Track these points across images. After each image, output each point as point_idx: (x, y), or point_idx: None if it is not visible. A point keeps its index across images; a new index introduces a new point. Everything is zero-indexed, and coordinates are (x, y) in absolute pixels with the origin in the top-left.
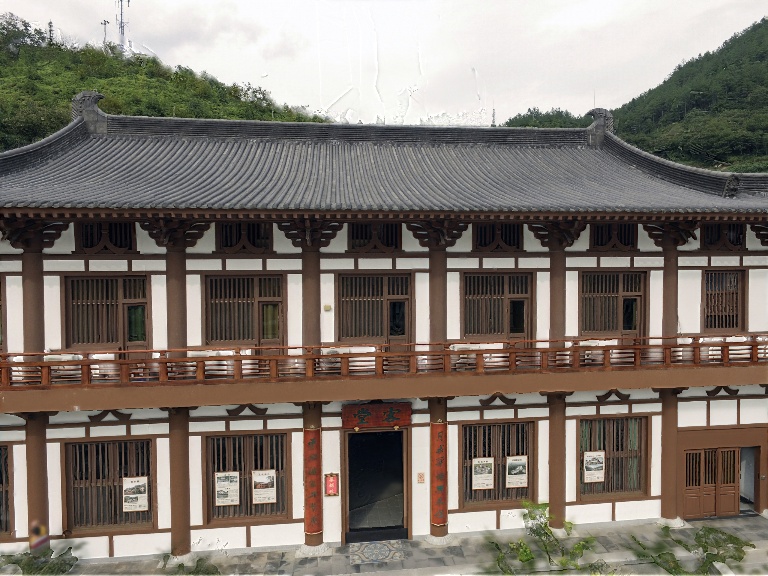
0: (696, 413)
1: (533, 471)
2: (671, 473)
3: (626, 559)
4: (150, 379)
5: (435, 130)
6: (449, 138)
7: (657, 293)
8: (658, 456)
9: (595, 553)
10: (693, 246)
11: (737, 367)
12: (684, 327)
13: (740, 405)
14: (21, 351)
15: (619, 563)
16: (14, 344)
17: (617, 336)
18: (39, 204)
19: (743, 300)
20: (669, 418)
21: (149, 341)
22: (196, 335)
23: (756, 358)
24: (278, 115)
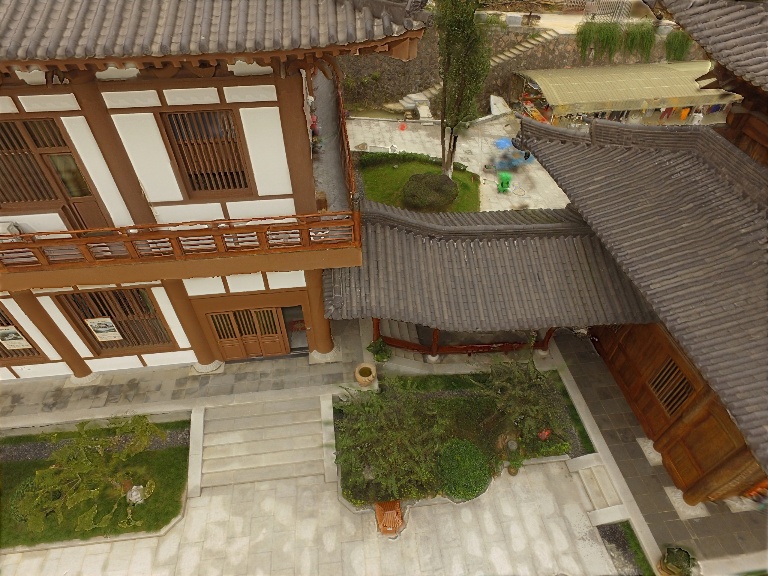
0: (208, 283)
1: (27, 338)
2: (192, 333)
3: (111, 415)
4: None
5: None
6: None
7: (89, 151)
8: (174, 320)
9: (89, 408)
10: (125, 71)
11: (195, 260)
12: (155, 194)
13: (266, 273)
14: None
15: (103, 419)
16: None
17: (55, 209)
18: None
19: (243, 153)
20: (170, 290)
21: None
22: None
23: (223, 248)
24: None
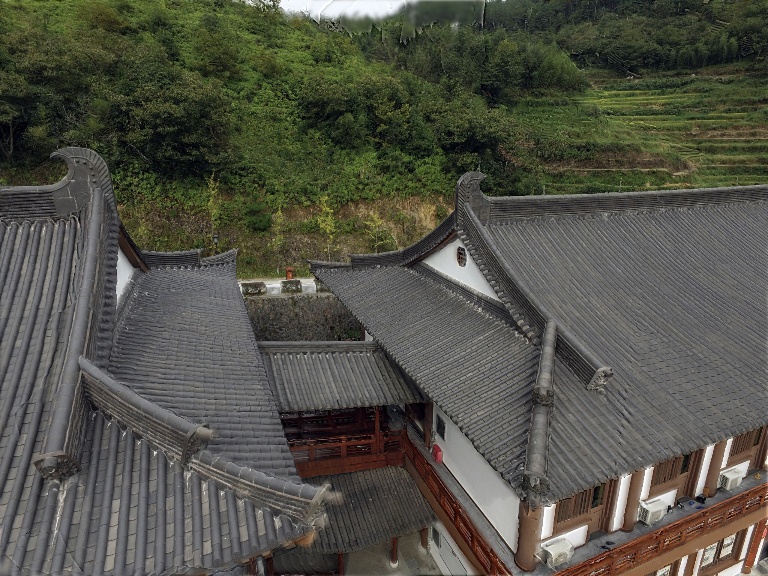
0: None
1: None
2: None
3: None
4: (736, 514)
5: (729, 192)
6: (736, 198)
7: None
8: None
9: None
10: None
11: None
12: None
13: None
14: (624, 508)
15: None
16: (621, 505)
17: None
18: (762, 425)
19: None
20: None
21: (699, 474)
22: (725, 460)
23: None
24: (289, 29)
